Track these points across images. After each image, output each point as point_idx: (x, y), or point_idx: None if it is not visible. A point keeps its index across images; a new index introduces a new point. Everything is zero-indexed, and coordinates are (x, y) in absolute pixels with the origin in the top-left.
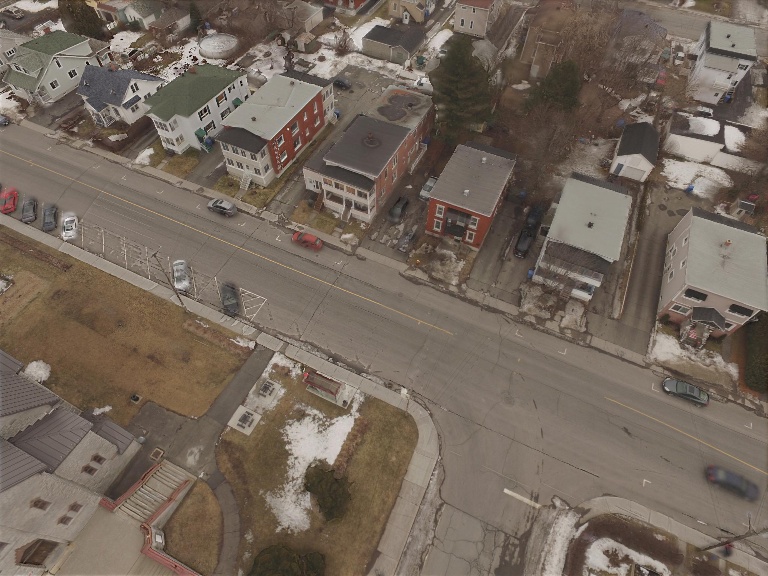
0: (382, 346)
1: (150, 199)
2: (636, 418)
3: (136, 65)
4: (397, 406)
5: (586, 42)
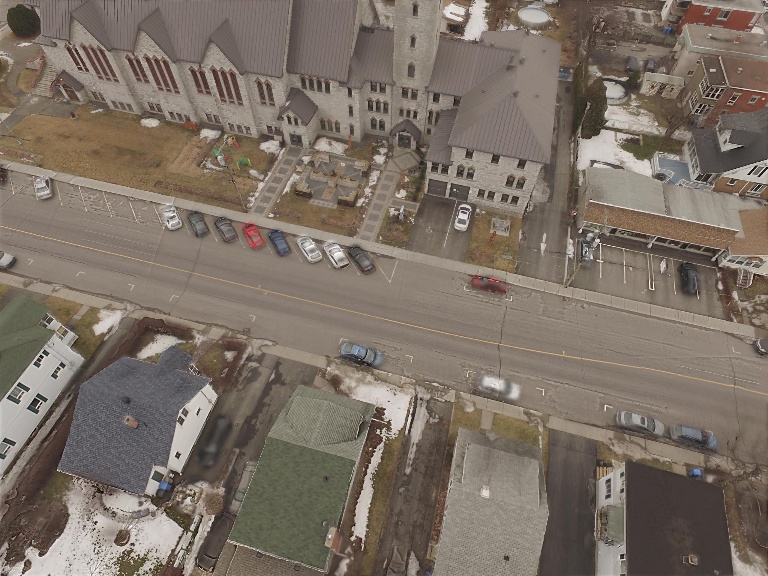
0: None
1: (91, 262)
2: None
3: None
4: None
5: None
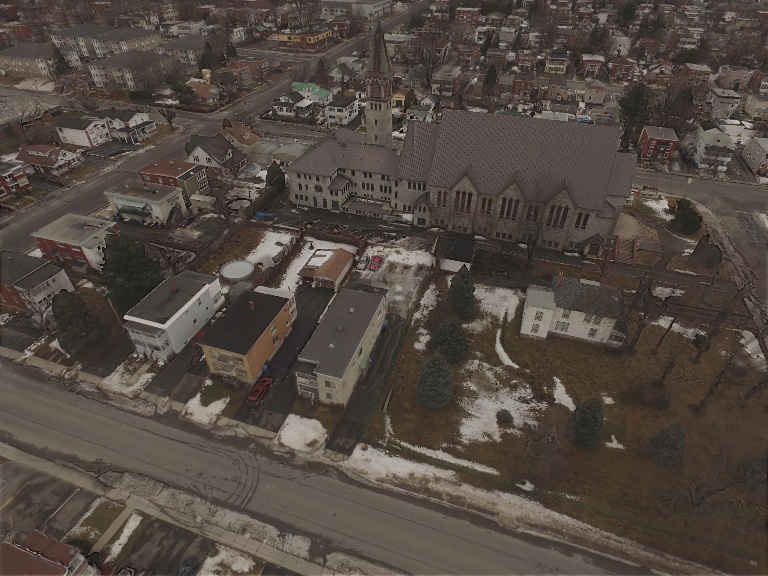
0: (657, 186)
1: None
2: (767, 195)
3: None
4: (678, 197)
5: (684, 86)
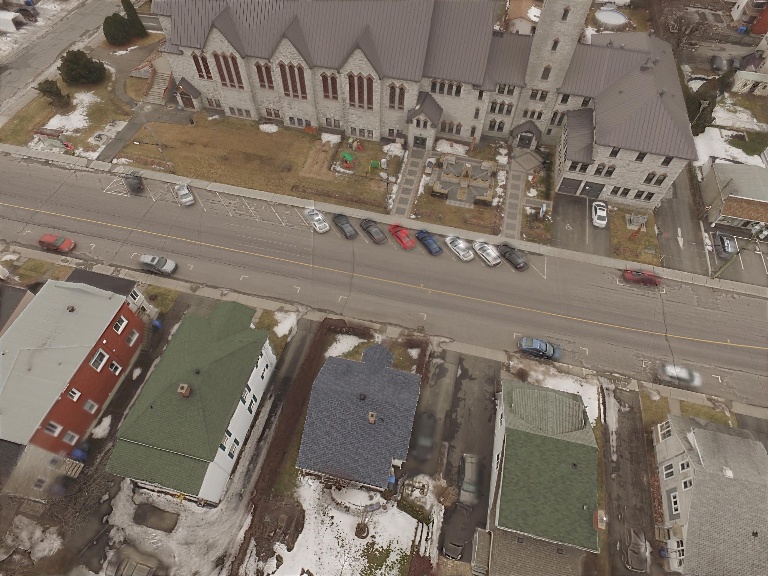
0: (4, 174)
1: (251, 266)
2: None
3: (429, 572)
4: (4, 144)
5: None
